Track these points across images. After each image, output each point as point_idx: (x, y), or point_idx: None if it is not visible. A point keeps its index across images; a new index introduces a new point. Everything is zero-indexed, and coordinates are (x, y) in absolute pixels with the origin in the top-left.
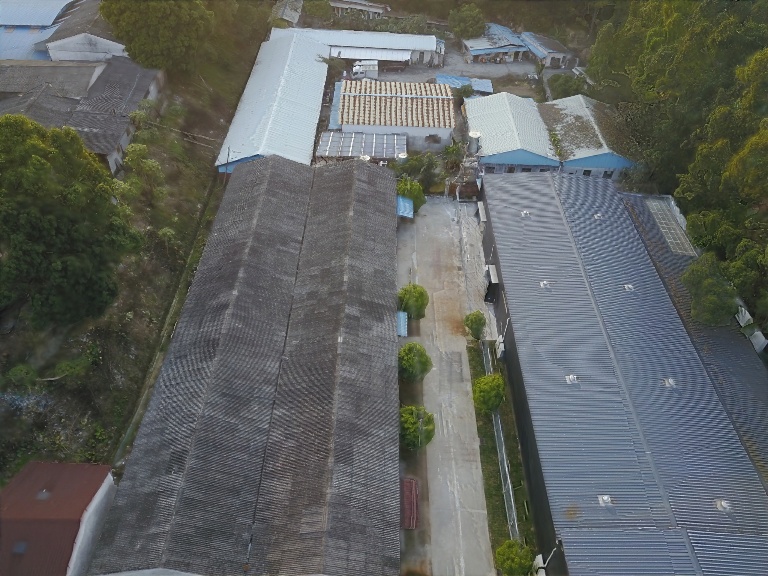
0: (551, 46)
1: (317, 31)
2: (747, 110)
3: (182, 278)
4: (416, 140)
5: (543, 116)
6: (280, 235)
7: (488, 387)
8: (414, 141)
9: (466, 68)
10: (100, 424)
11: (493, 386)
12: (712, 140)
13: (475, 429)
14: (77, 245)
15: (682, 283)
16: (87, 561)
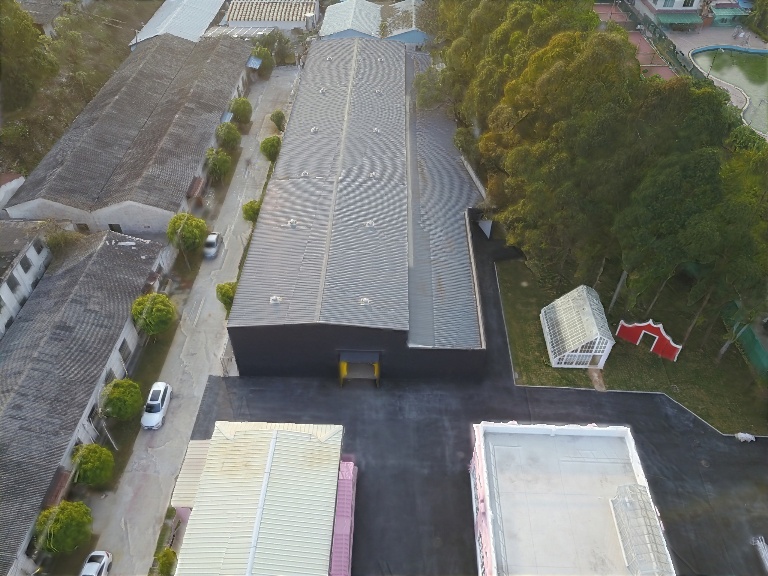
0: None
1: None
2: None
3: None
4: (285, 32)
5: (383, 13)
6: (158, 74)
7: (267, 141)
8: (284, 33)
9: None
10: (25, 167)
11: (270, 140)
12: None
13: (266, 175)
14: (8, 54)
15: (413, 87)
16: (7, 216)
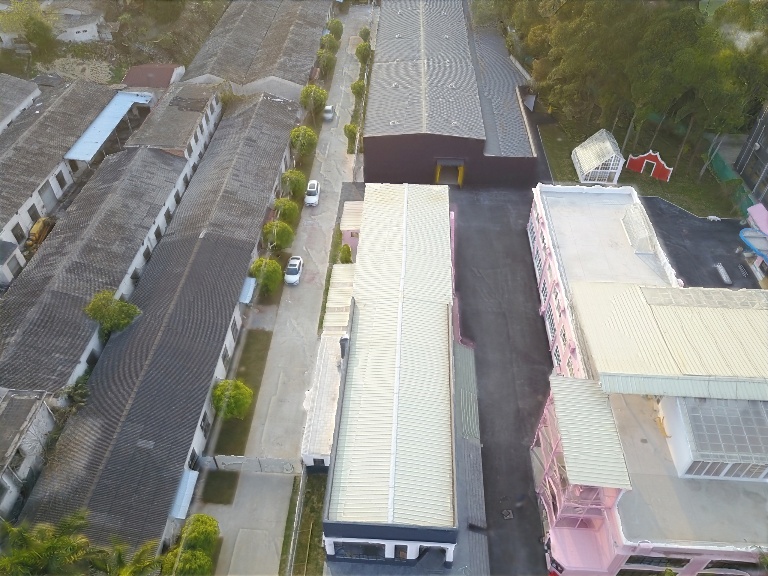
0: None
1: None
2: None
3: None
4: None
5: None
6: (267, 3)
7: (361, 45)
8: None
9: None
10: None
11: (364, 45)
12: None
13: (358, 74)
14: None
15: (470, 9)
16: None
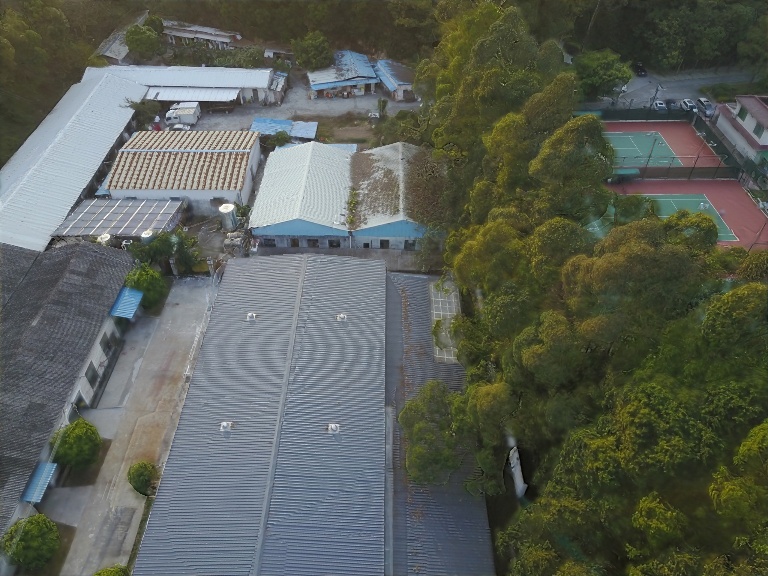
0: (404, 77)
1: (137, 69)
2: (501, 188)
3: None
4: (200, 204)
5: (353, 170)
6: None
7: None
8: (198, 205)
9: (306, 105)
10: None
11: None
12: (474, 221)
13: None
14: None
15: None
16: None
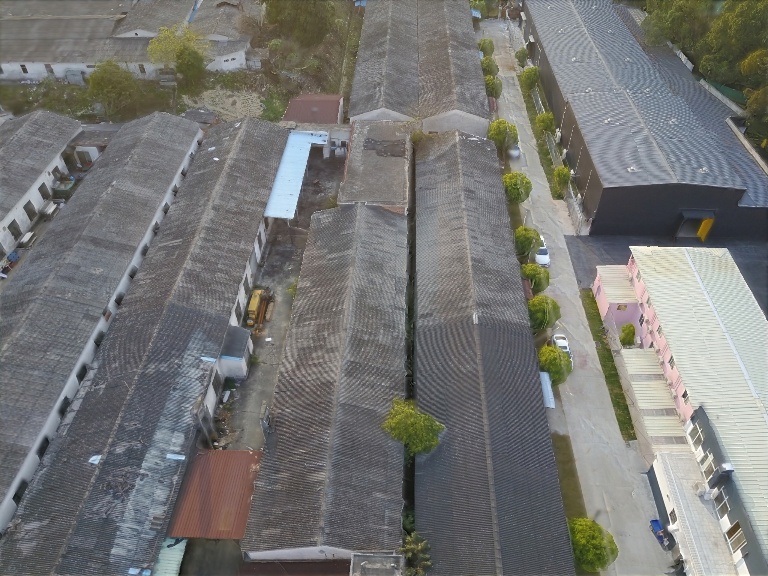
0: None
1: None
2: None
3: (346, 52)
4: None
5: None
6: (405, 21)
7: (530, 70)
8: None
9: None
10: (326, 93)
11: (533, 69)
12: None
13: (523, 101)
14: None
15: (641, 27)
16: None
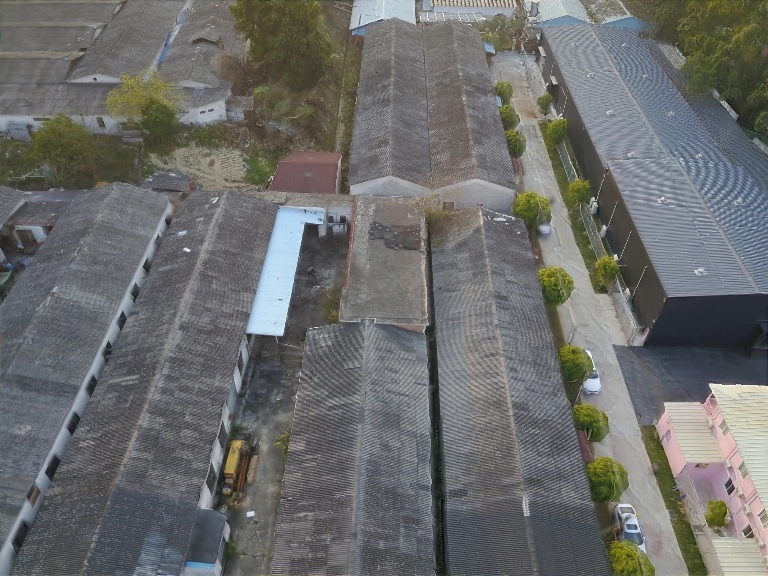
0: None
1: None
2: None
3: (342, 92)
4: (487, 18)
5: (581, 1)
6: (410, 58)
7: (558, 123)
8: None
9: None
10: (321, 147)
11: (561, 123)
12: None
13: (548, 157)
14: (308, 36)
15: (680, 72)
16: None
